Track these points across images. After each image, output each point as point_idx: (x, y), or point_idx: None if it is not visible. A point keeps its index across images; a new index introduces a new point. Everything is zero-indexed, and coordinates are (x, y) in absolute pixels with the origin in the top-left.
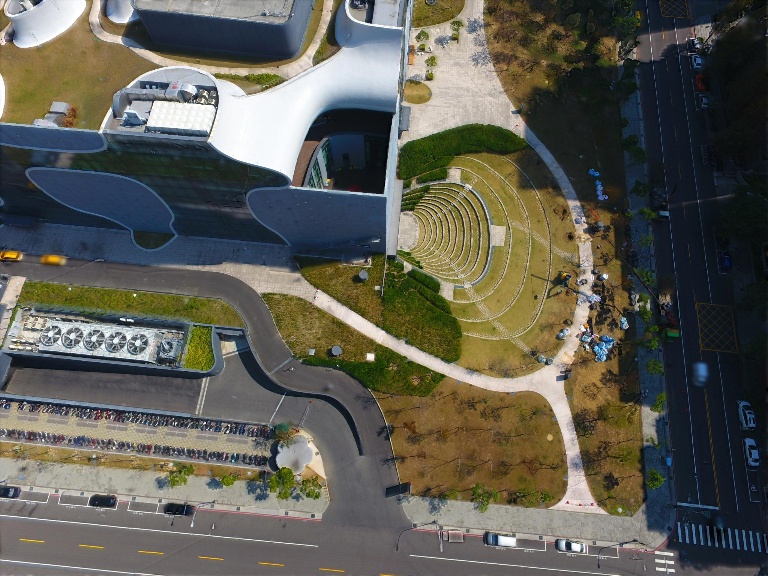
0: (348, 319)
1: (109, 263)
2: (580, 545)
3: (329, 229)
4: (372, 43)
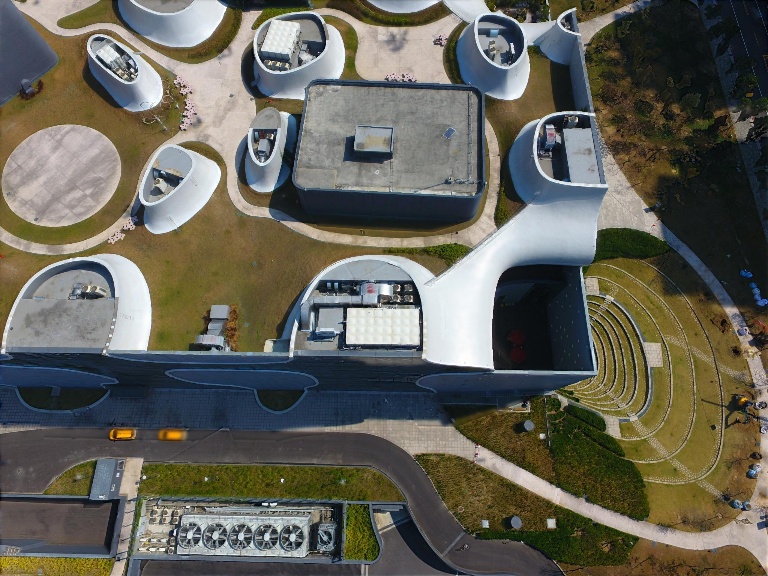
0: (518, 478)
1: (235, 432)
2: None
3: (497, 386)
4: (567, 200)
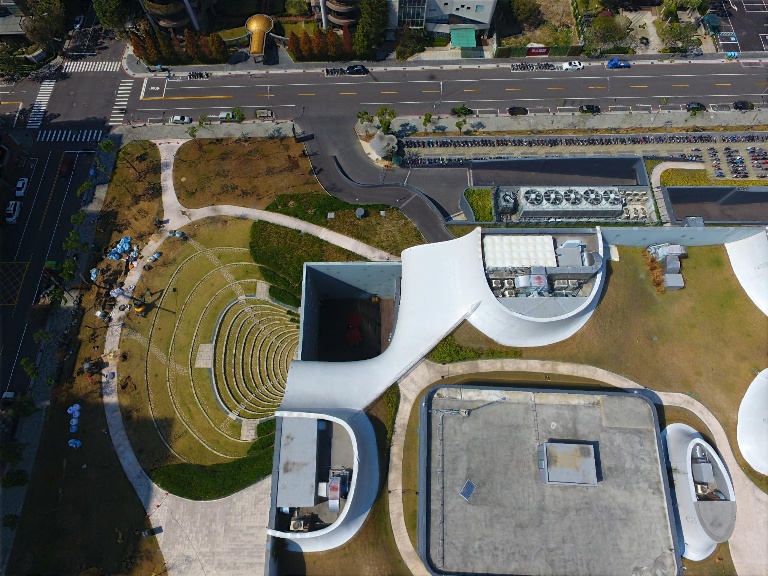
0: (354, 243)
1: None
2: (174, 119)
3: None
4: (320, 409)
